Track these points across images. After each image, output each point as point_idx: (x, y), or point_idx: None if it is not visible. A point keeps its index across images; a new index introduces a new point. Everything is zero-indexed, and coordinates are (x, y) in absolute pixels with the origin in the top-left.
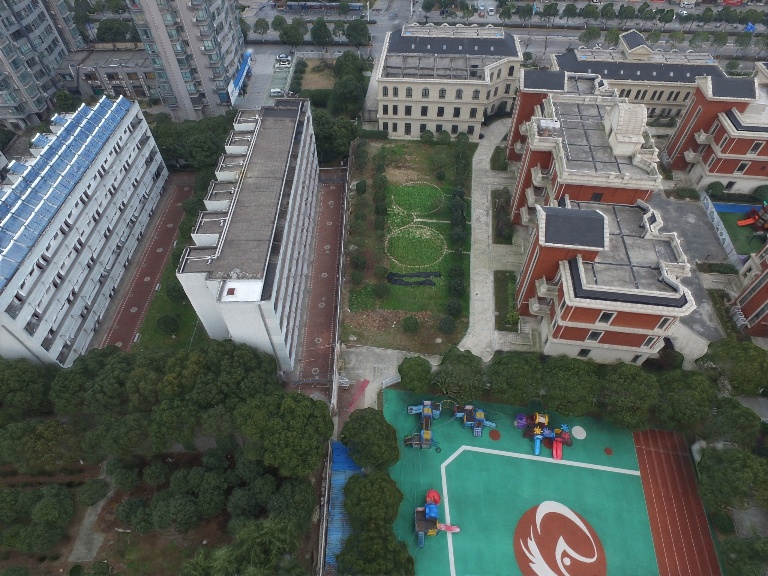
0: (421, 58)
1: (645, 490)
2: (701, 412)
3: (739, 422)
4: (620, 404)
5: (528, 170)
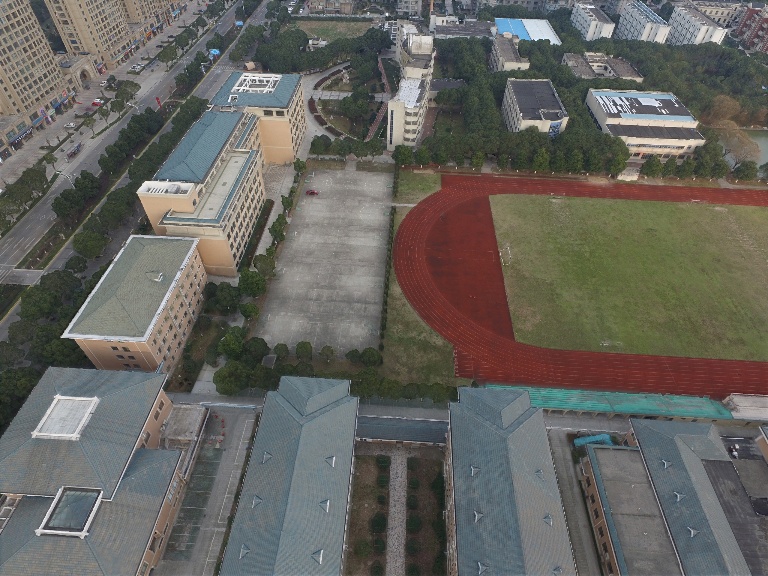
0: (705, 3)
1: None
2: None
3: None
4: None
5: (761, 25)
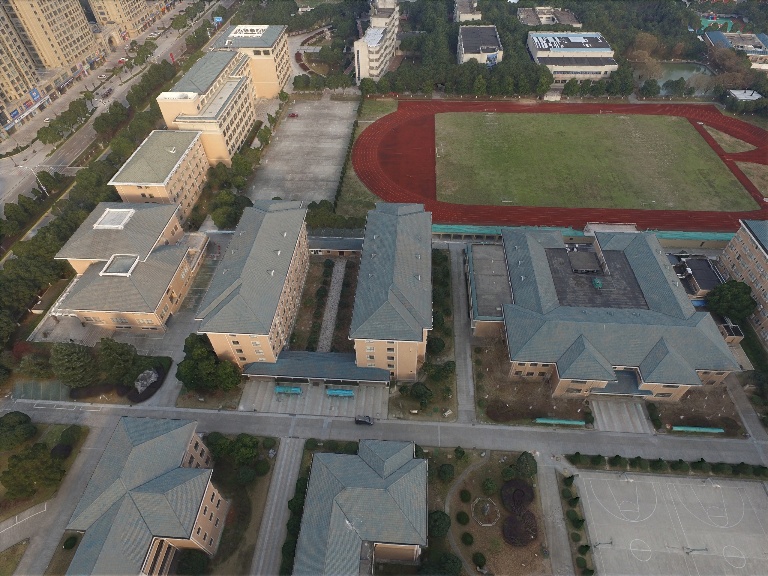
0: None
1: (733, 22)
2: (745, 5)
3: (752, 4)
4: (729, 6)
5: None
